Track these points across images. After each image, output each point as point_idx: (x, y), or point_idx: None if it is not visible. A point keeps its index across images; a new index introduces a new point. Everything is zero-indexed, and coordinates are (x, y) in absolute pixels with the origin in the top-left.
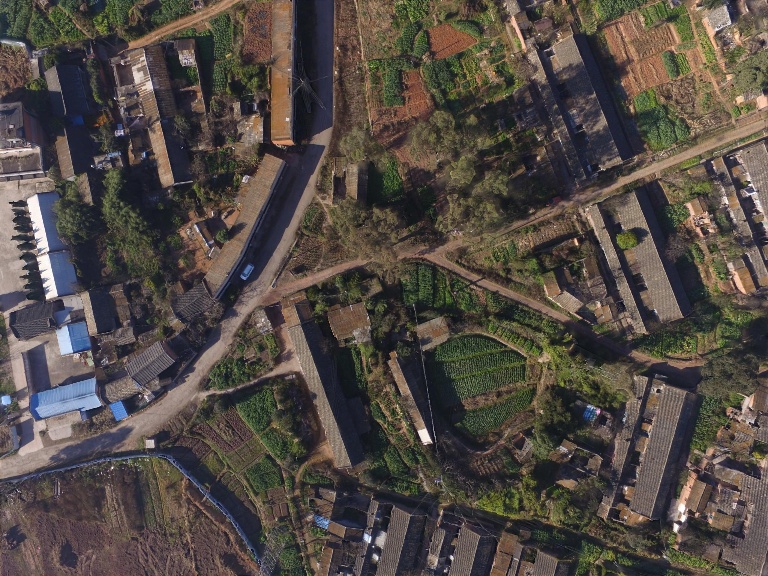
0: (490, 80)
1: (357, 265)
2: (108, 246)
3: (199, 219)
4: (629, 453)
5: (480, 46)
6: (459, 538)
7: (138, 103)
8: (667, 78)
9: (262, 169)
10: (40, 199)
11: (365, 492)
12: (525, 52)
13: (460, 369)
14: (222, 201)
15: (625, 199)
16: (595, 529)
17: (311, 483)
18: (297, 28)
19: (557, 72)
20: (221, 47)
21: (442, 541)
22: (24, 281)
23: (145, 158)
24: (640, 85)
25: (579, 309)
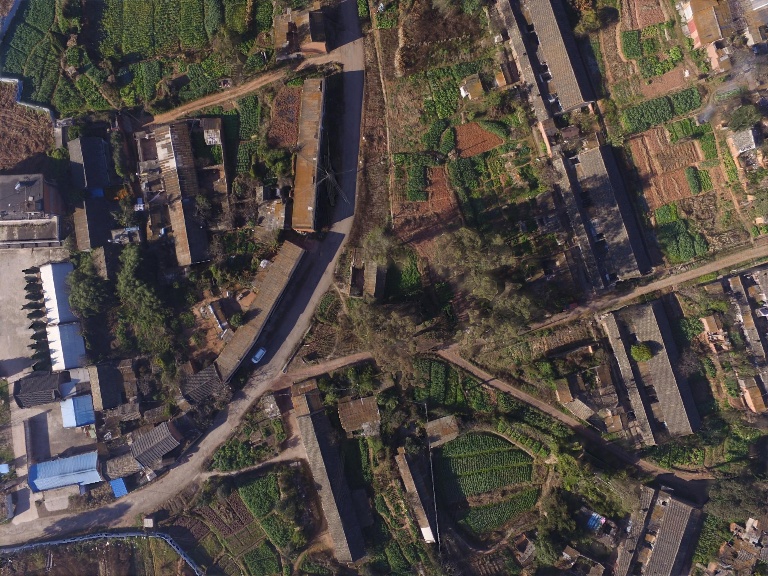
0: (514, 182)
1: (370, 356)
2: (119, 319)
3: (213, 298)
4: (632, 564)
5: (506, 147)
6: None
7: (160, 179)
8: (689, 193)
9: (281, 256)
10: (54, 269)
11: None
12: (550, 157)
13: (467, 466)
14: (238, 282)
15: (642, 312)
16: None
17: (309, 572)
18: (325, 115)
19: (581, 180)
20: (247, 127)
21: None
22: None
23: (163, 235)
24: (662, 198)
25: (590, 417)
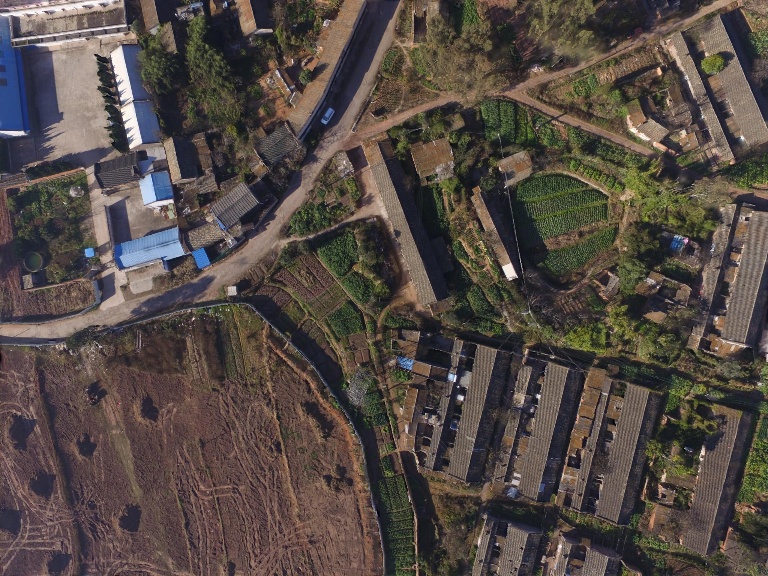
0: None
1: (437, 105)
2: (189, 98)
3: None
4: (719, 282)
5: None
6: (546, 375)
7: None
8: None
9: (343, 11)
10: (124, 50)
11: (448, 334)
12: None
13: (541, 209)
14: (302, 49)
15: (709, 24)
16: (685, 362)
17: (393, 327)
18: None
19: None
20: None
21: (529, 378)
22: (106, 138)
23: (227, 8)
24: None
25: (664, 138)
